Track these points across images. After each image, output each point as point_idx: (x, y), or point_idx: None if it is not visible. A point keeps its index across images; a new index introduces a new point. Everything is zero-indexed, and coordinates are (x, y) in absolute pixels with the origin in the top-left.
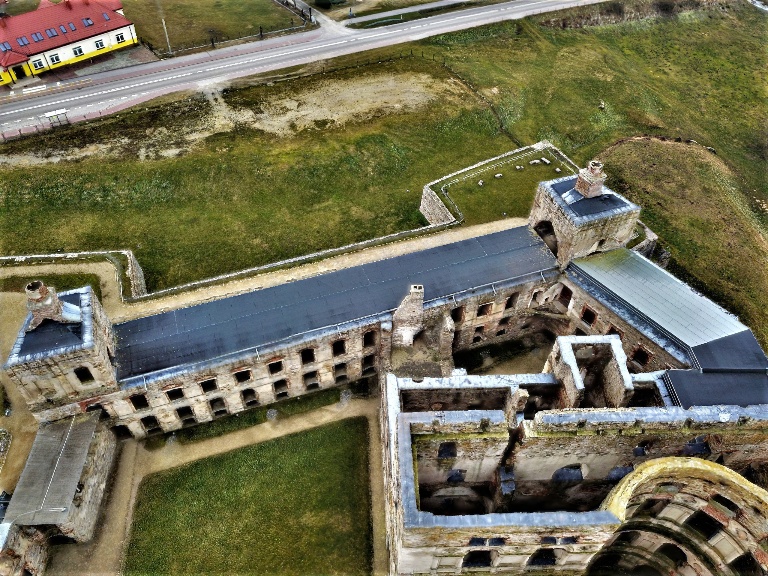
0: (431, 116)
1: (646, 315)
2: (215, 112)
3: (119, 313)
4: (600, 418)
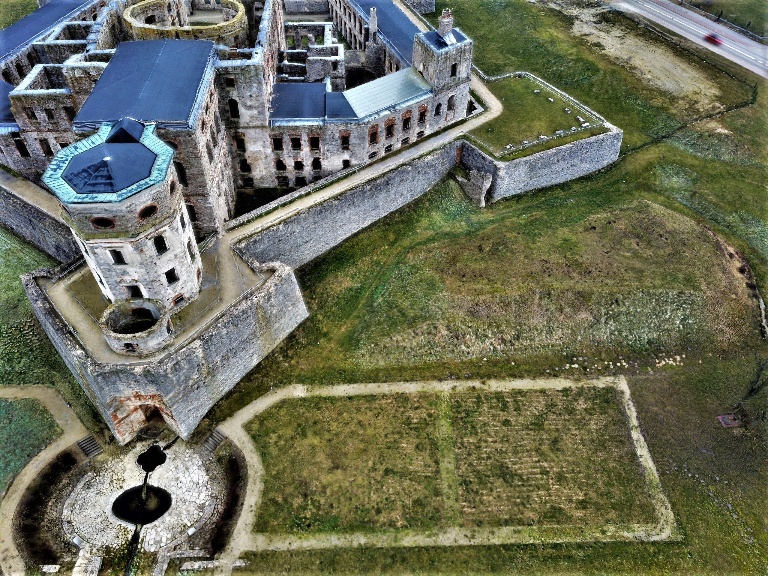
0: (642, 91)
1: None
2: (586, 9)
3: None
4: (267, 2)
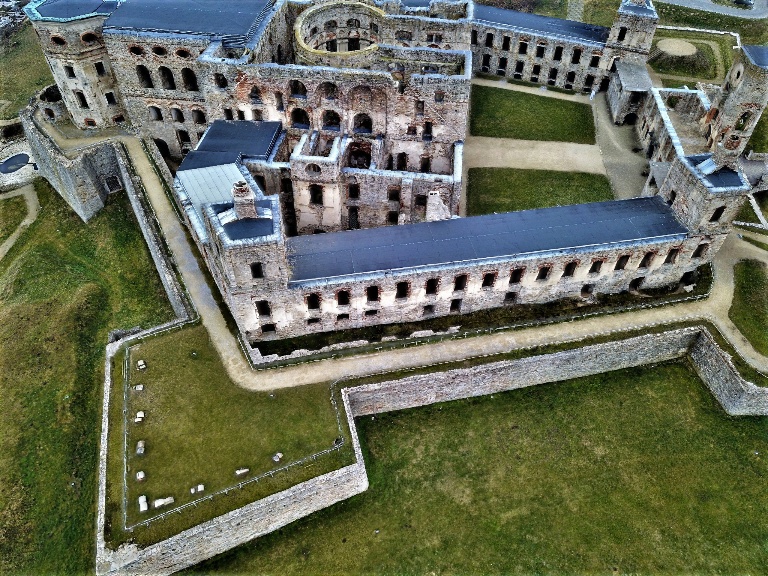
0: None
1: (248, 184)
2: None
3: (708, 310)
4: (360, 69)
